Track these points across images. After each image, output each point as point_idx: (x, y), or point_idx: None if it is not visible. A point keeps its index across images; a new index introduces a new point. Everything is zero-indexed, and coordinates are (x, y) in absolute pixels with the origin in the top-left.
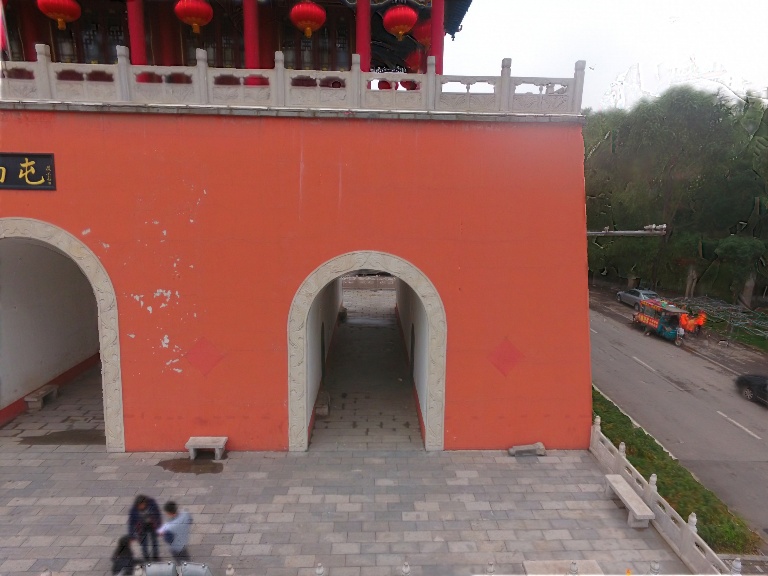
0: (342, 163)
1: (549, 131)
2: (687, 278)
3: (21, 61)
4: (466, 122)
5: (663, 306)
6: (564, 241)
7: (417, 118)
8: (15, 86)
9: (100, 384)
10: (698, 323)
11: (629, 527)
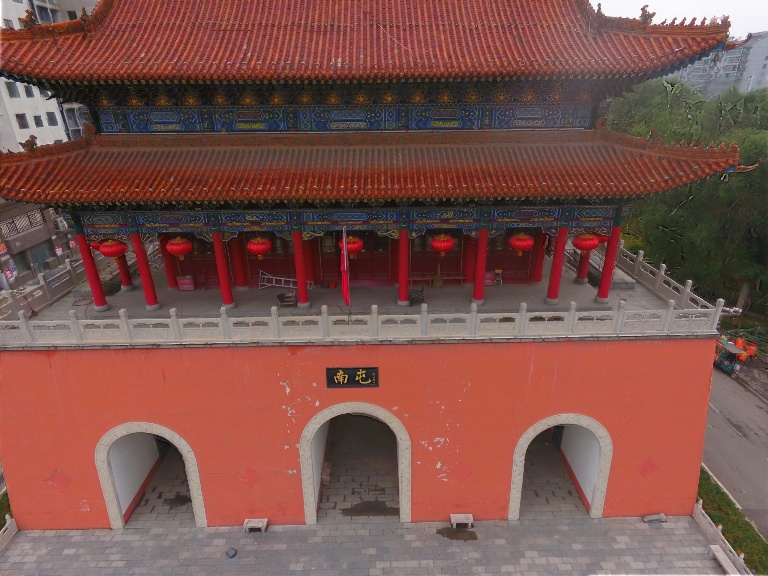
0: (557, 365)
1: (694, 343)
2: (740, 293)
3: (360, 315)
4: (640, 339)
5: (724, 344)
6: (694, 404)
7: (609, 339)
8: (355, 329)
9: (348, 453)
10: (750, 354)
11: None
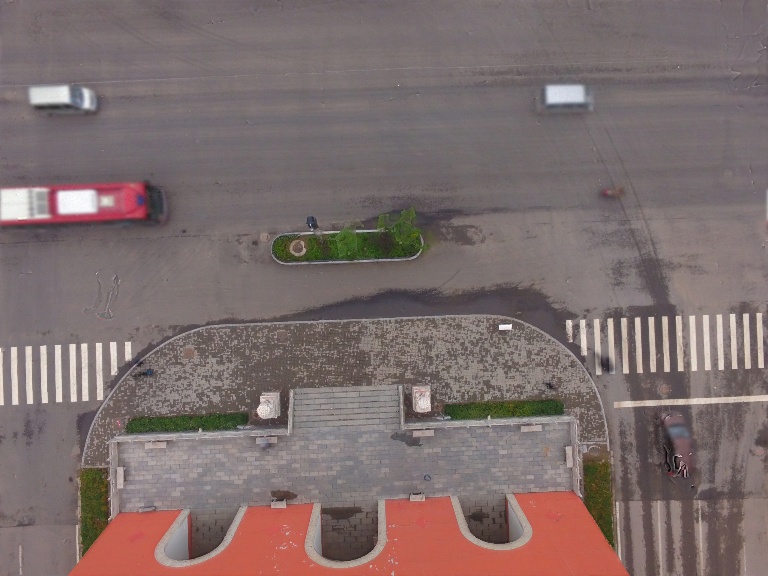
0: None
1: None
2: None
3: None
4: None
5: None
6: None
7: None
8: None
9: None
10: None
11: (127, 467)
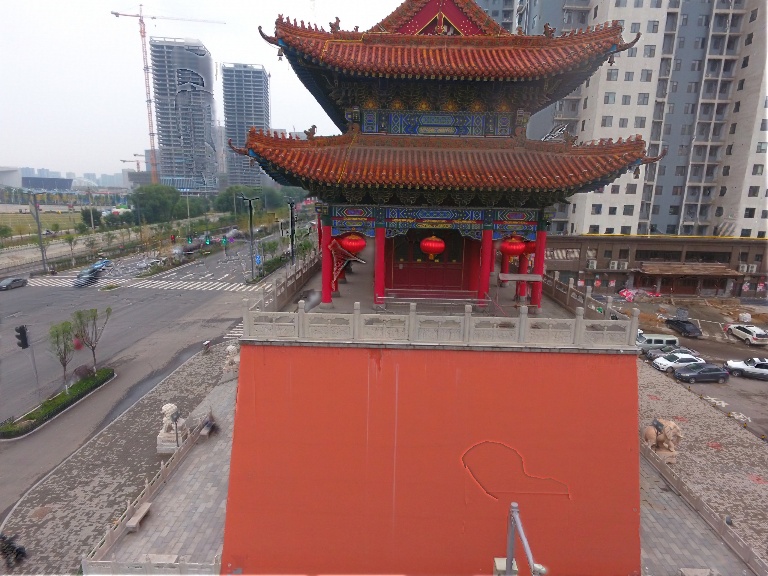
0: None
1: None
2: None
3: None
4: None
5: None
6: None
7: None
8: None
9: None
10: None
11: None
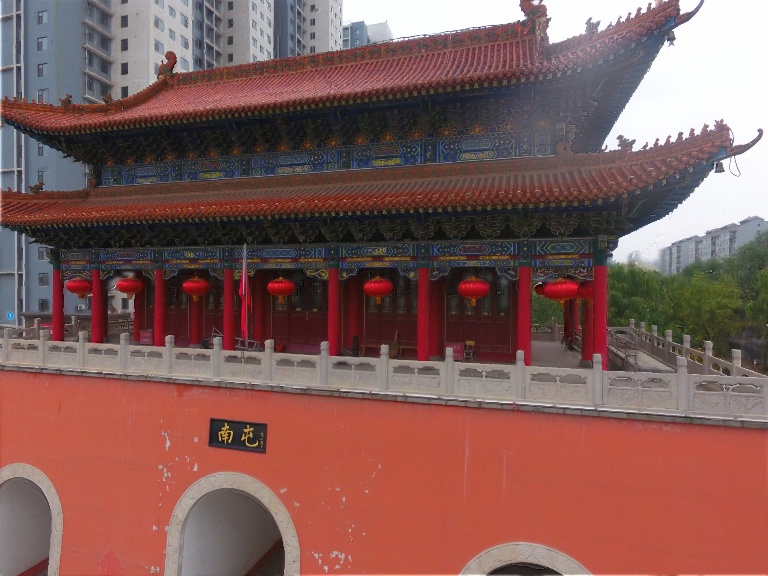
0: (506, 451)
1: (742, 436)
2: None
3: None
4: (639, 420)
5: None
6: None
7: (584, 414)
8: (248, 370)
9: None
10: None
11: None
